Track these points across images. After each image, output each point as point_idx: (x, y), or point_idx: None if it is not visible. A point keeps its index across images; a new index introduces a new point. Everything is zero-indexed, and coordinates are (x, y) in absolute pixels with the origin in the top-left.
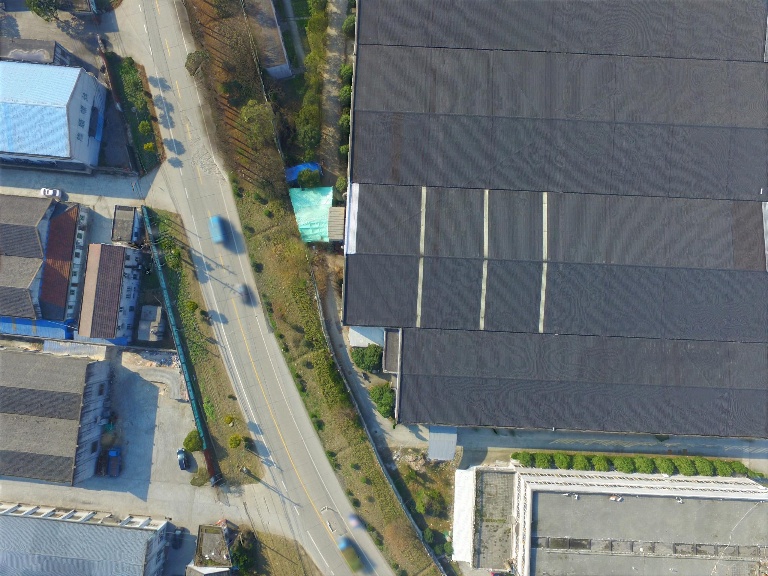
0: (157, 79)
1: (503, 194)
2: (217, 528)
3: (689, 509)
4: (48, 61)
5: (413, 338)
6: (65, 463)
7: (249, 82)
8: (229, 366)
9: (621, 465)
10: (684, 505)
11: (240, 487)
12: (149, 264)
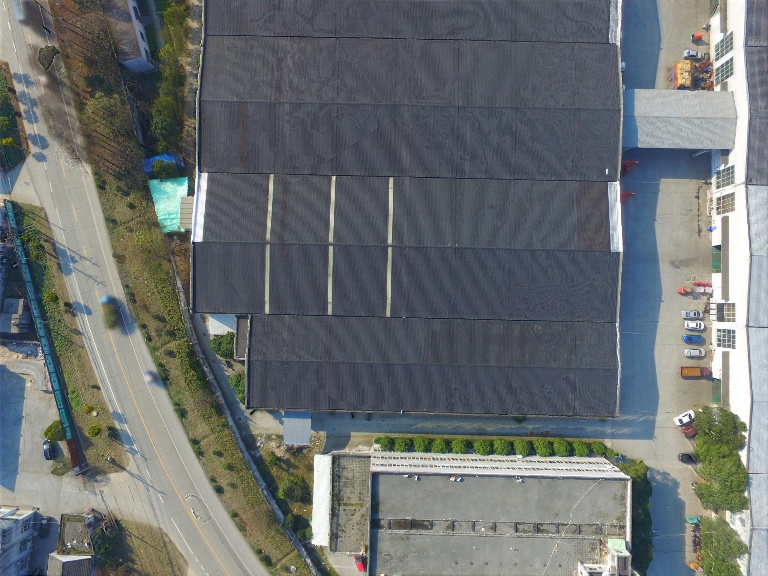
0: (21, 75)
1: (350, 180)
2: (79, 516)
3: (530, 488)
4: None
5: (262, 324)
6: None
7: (111, 76)
8: (93, 357)
9: (478, 447)
10: (525, 484)
11: (106, 476)
12: (15, 258)
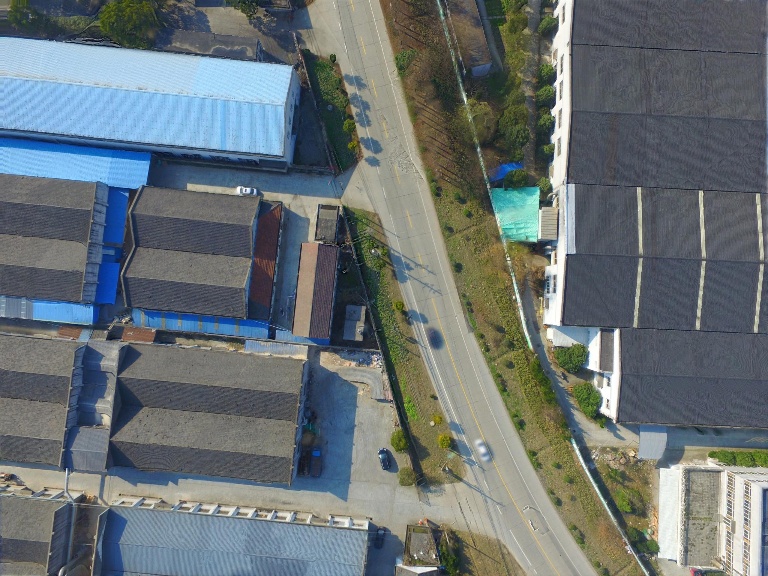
0: (353, 77)
1: (717, 195)
2: (425, 528)
3: None
4: (251, 58)
5: (630, 338)
6: (280, 463)
7: (446, 81)
8: (430, 366)
9: None
10: None
11: (440, 486)
12: (346, 263)
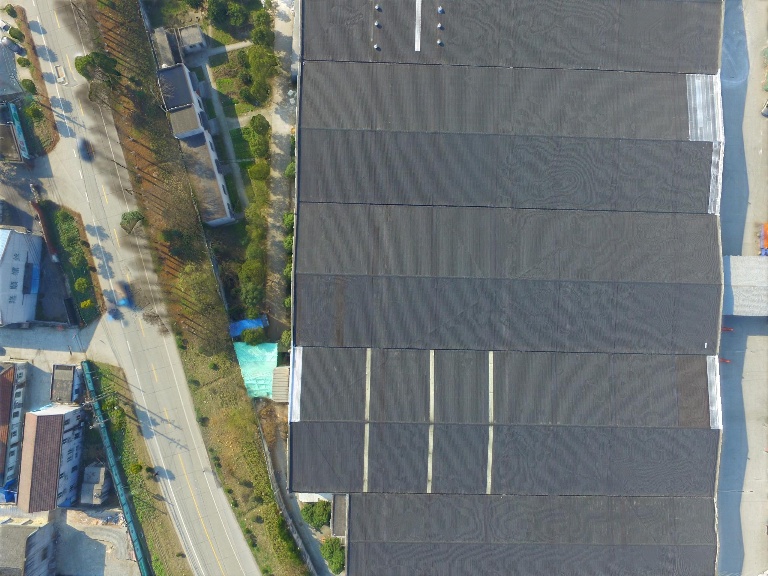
0: (94, 227)
1: (449, 354)
2: None
3: None
4: None
5: (360, 503)
6: None
7: (190, 230)
8: (177, 523)
9: None
10: None
11: None
12: (92, 419)
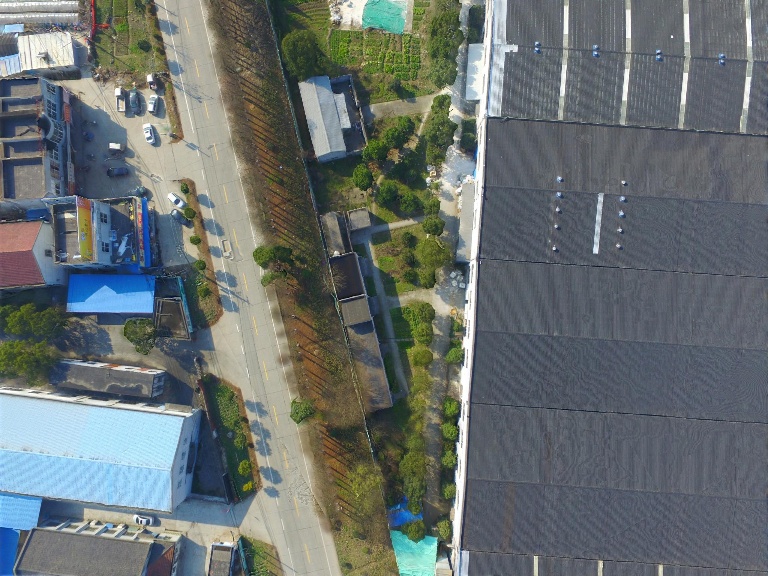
0: (254, 403)
1: (618, 566)
2: None
3: None
4: (146, 396)
5: None
6: None
7: (349, 410)
8: None
9: None
10: None
11: None
12: None
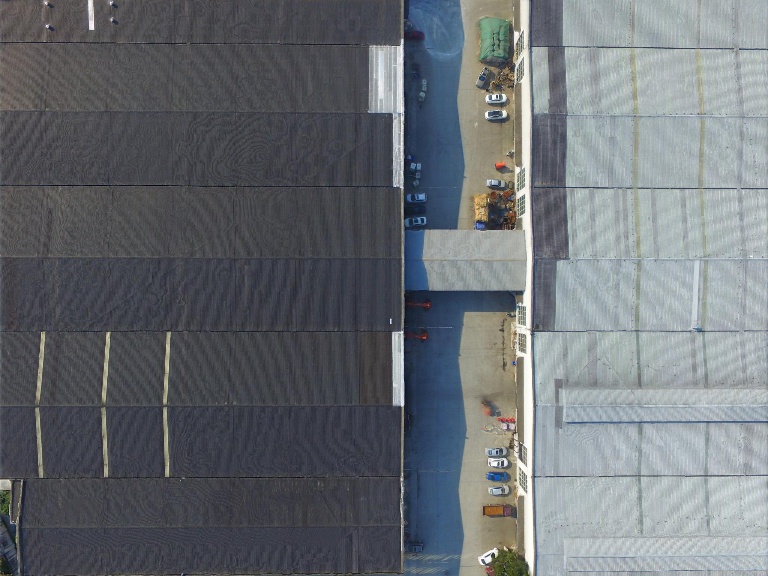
0: None
1: (125, 336)
2: None
3: None
4: None
5: (36, 489)
6: None
7: None
8: None
9: None
10: None
11: None
12: None
